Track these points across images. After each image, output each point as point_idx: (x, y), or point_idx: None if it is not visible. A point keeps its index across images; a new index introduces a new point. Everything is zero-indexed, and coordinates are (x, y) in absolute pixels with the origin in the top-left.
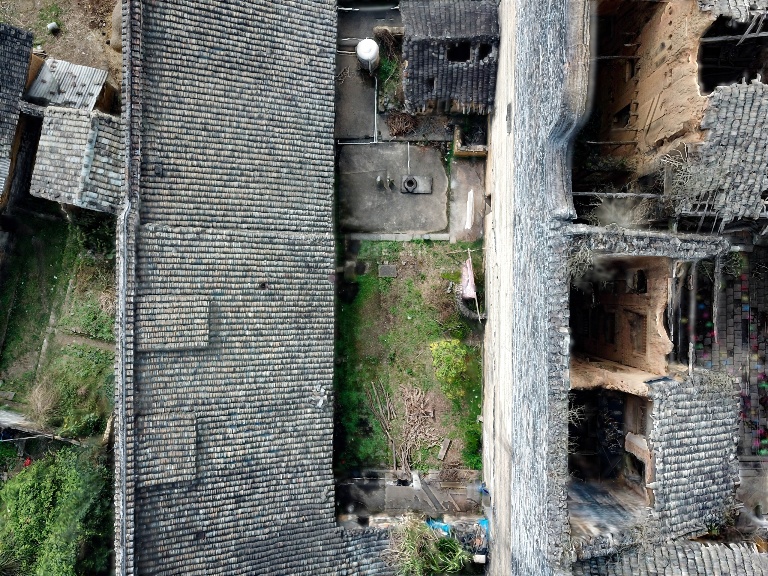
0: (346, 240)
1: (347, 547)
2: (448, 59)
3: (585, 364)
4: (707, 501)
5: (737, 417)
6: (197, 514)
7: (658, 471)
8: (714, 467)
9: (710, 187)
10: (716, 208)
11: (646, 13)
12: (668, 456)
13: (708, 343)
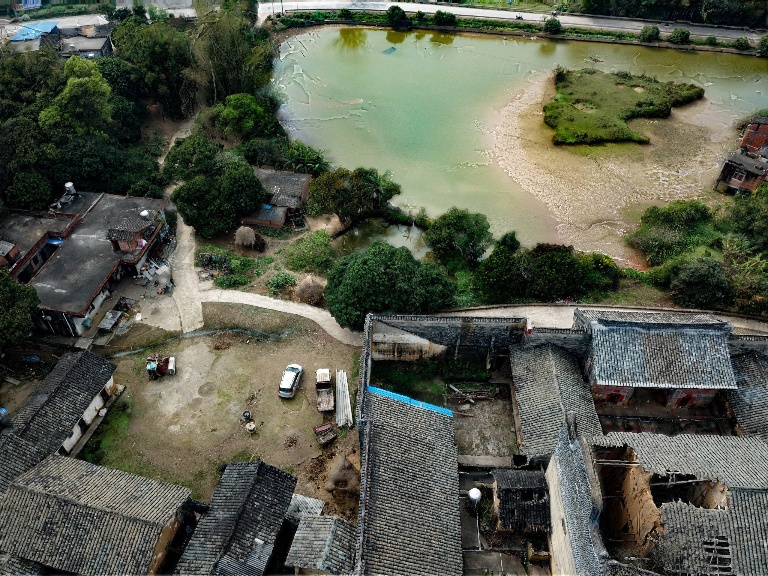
0: None
1: None
2: (521, 499)
3: None
4: None
5: None
6: None
7: None
8: None
9: (677, 555)
10: (685, 568)
11: (622, 476)
12: None
13: None
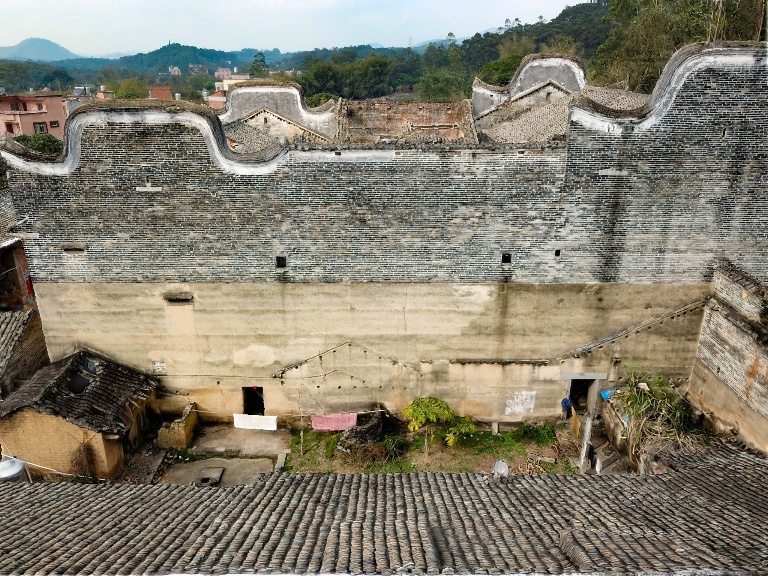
0: None
1: None
2: None
3: None
4: None
5: None
6: (759, 550)
7: None
8: None
9: None
10: None
11: None
12: None
13: None
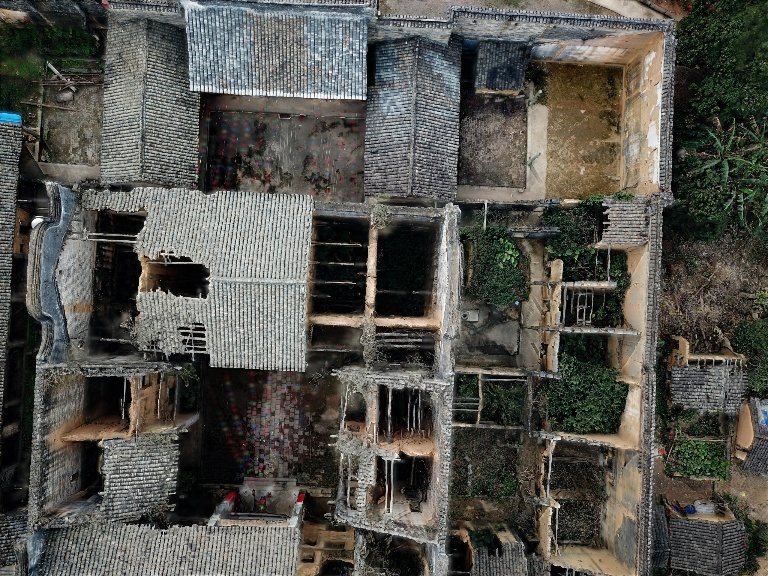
0: (36, 335)
1: (7, 526)
2: None
3: (120, 424)
4: (144, 502)
5: (174, 458)
6: None
7: (105, 486)
8: (151, 485)
9: (152, 338)
10: (160, 348)
11: None
12: (114, 478)
13: (259, 407)
